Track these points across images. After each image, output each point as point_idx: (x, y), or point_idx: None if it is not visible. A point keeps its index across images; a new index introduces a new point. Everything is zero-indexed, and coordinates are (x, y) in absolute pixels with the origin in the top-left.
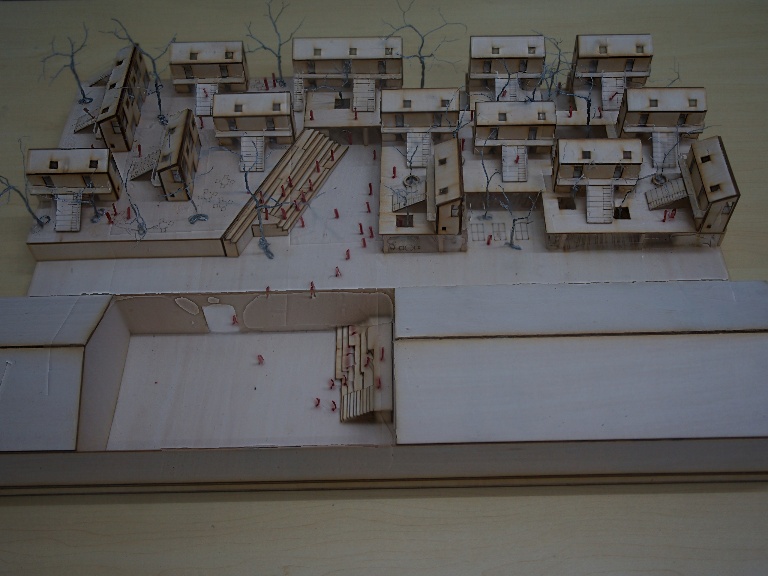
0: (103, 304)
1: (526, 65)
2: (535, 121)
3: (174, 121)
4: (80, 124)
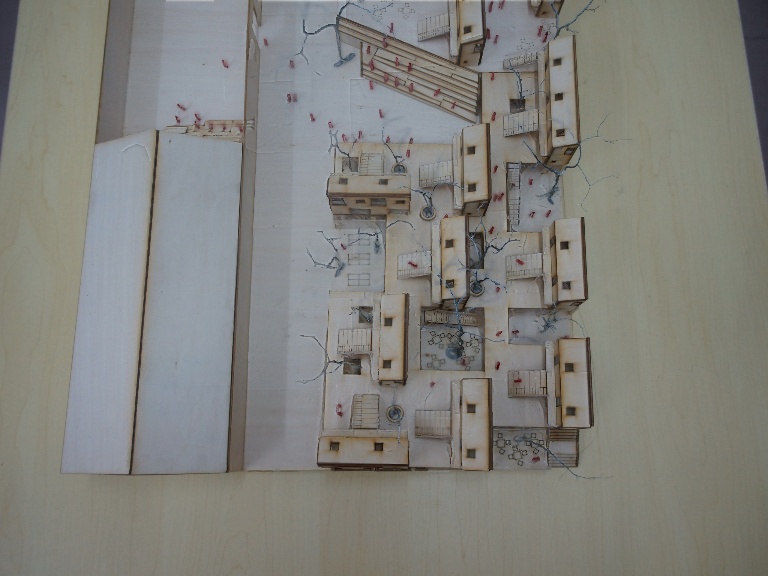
0: None
1: (555, 283)
2: (445, 277)
3: None
4: None
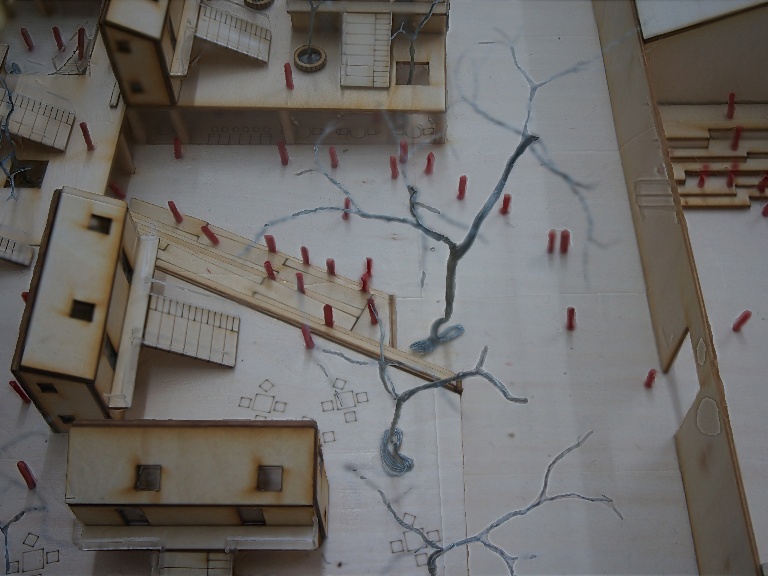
0: None
1: None
2: None
3: (104, 476)
4: None
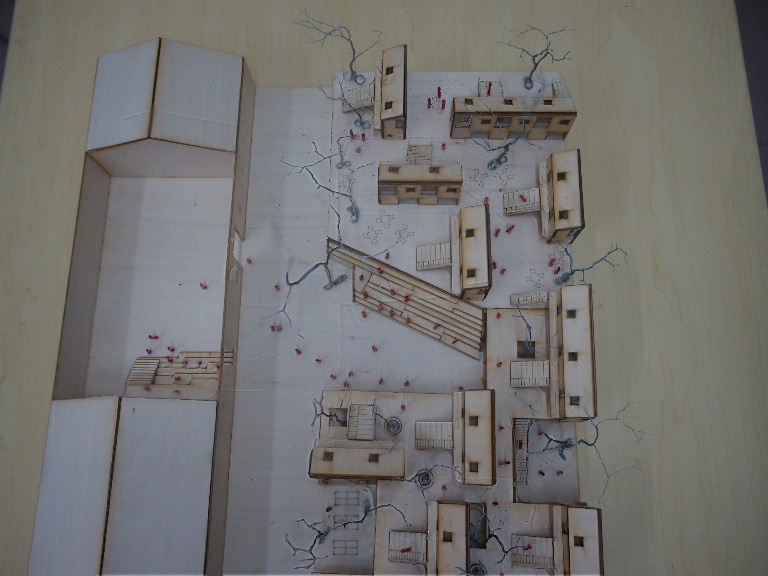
0: (217, 145)
1: None
2: None
3: (449, 170)
4: (488, 84)
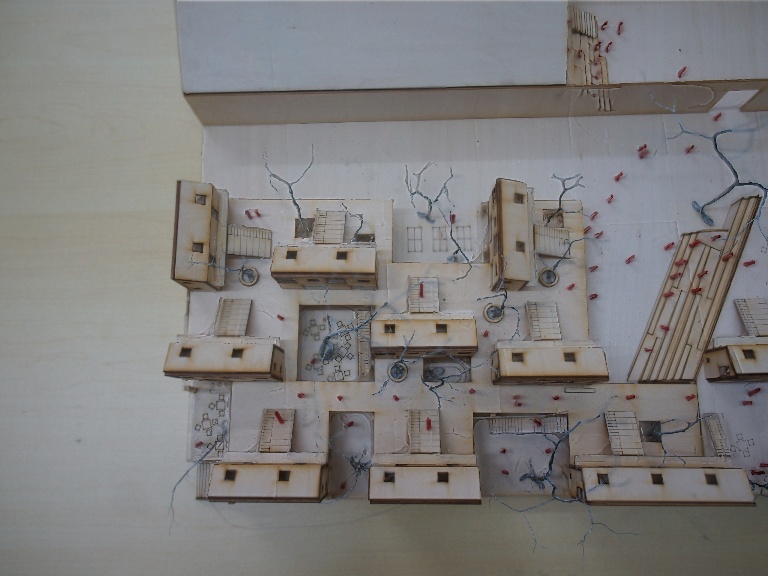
0: None
1: None
2: (399, 323)
3: None
4: None
